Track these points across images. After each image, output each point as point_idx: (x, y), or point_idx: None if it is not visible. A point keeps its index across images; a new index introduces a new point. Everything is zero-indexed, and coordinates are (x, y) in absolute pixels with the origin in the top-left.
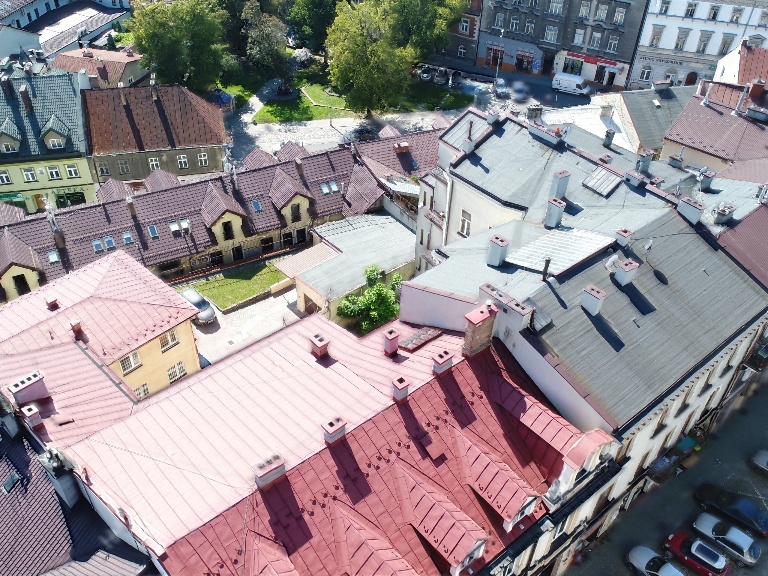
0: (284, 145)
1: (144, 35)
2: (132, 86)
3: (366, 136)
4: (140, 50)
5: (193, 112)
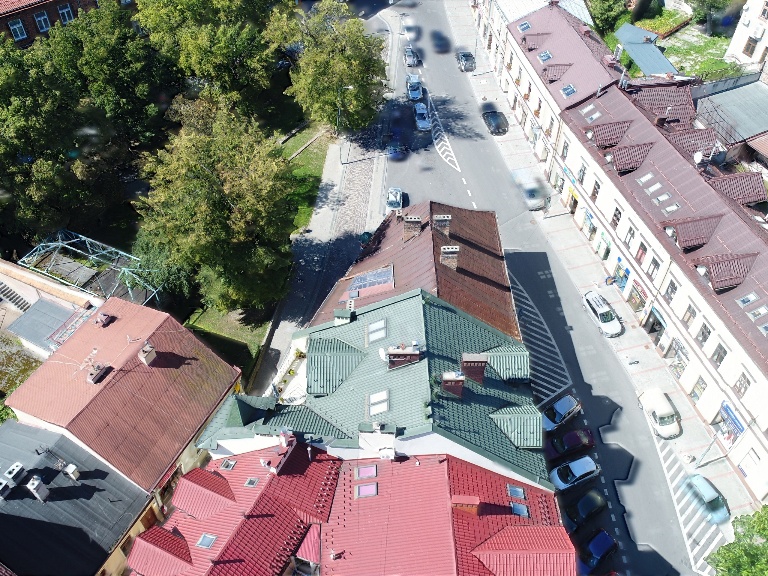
0: (595, 134)
1: (241, 226)
2: (433, 246)
3: (383, 141)
4: (221, 261)
5: (461, 214)
